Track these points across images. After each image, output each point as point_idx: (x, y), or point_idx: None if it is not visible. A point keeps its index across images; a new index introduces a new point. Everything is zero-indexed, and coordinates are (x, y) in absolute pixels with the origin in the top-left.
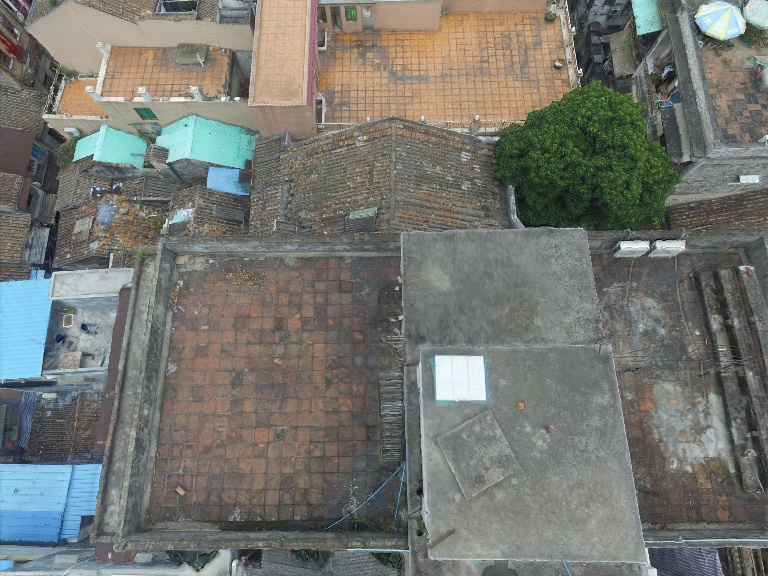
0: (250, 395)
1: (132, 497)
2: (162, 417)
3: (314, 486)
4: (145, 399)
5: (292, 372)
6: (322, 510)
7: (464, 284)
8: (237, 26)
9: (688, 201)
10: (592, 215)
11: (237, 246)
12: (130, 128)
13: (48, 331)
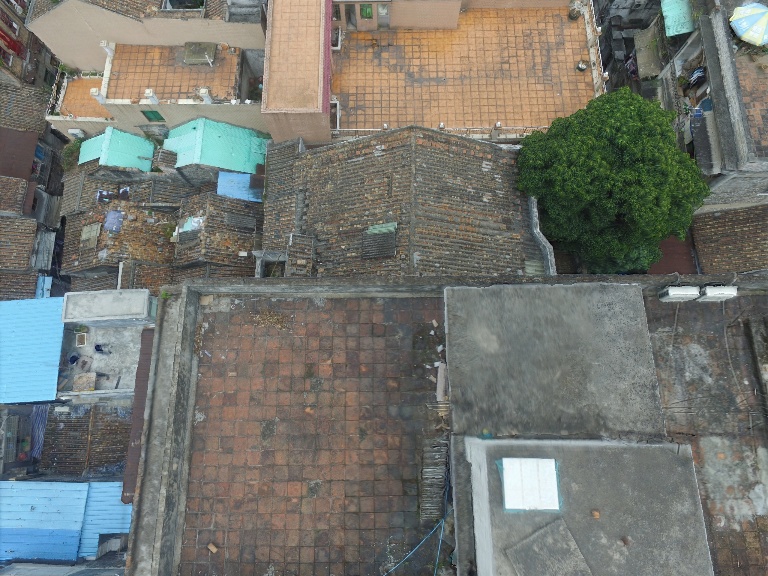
0: (281, 446)
1: (164, 557)
2: (191, 469)
3: (350, 543)
4: (174, 453)
5: (324, 422)
6: (359, 568)
7: (512, 345)
8: (247, 25)
9: (713, 210)
10: (616, 227)
11: (265, 288)
12: (136, 130)
13: (61, 351)
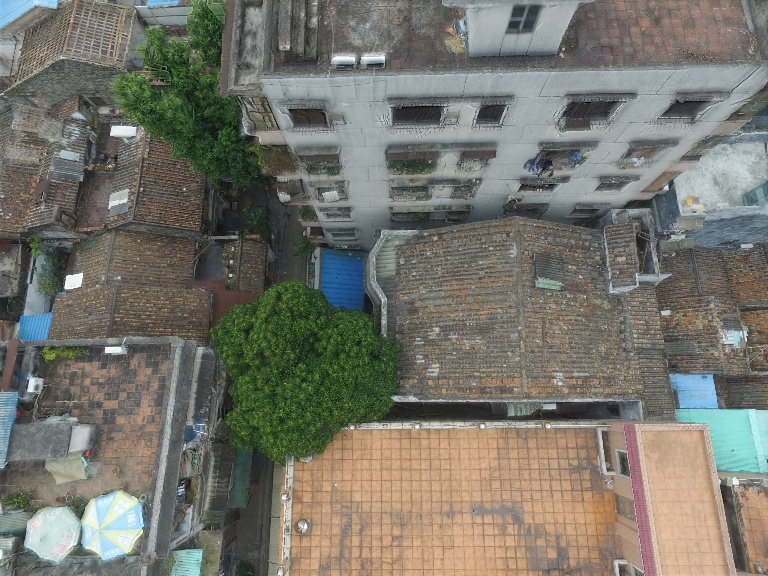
0: None
1: None
2: None
3: None
4: None
5: None
6: None
7: None
8: None
9: None
10: None
11: None
12: None
13: None
